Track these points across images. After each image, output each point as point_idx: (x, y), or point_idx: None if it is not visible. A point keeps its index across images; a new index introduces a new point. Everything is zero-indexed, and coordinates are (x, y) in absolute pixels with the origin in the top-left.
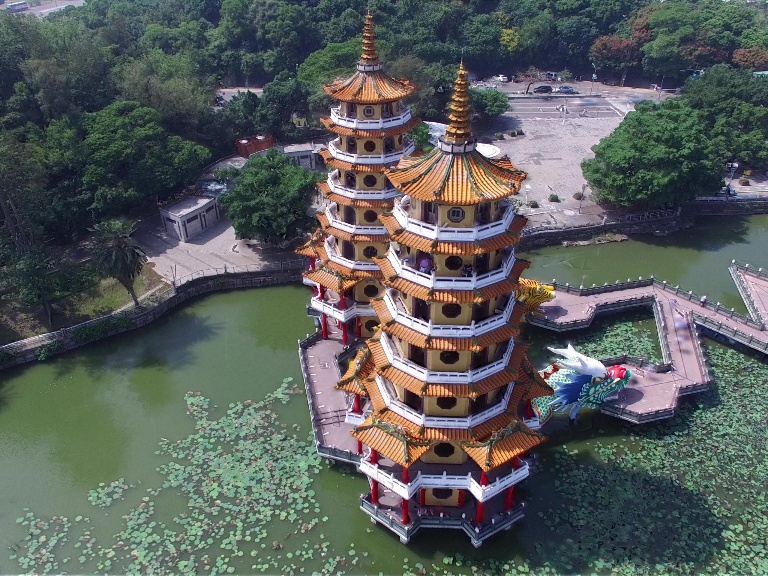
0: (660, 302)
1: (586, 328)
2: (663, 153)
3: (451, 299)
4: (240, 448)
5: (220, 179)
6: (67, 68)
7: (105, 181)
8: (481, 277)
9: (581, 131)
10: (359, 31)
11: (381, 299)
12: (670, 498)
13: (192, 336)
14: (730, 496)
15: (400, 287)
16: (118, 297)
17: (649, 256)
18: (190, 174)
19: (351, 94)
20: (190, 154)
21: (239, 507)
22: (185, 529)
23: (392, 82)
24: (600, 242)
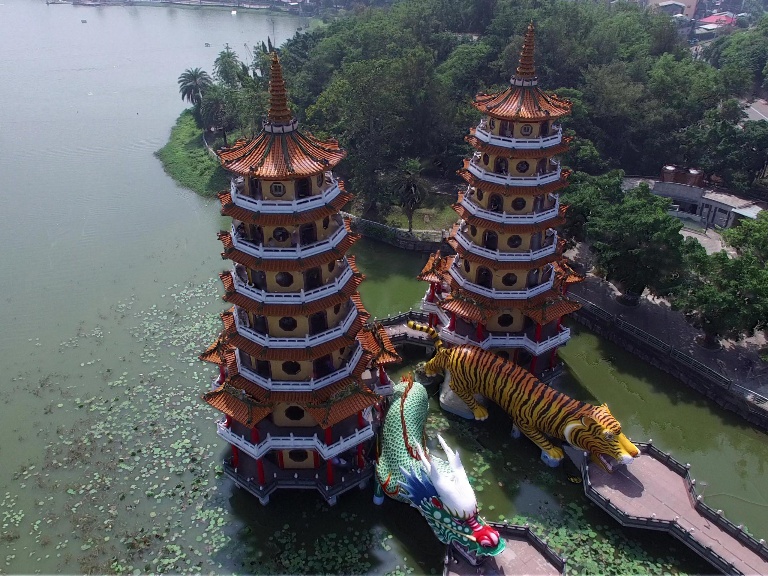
0: None
1: (620, 524)
2: None
3: None
4: None
5: None
6: (557, 50)
7: None
8: (242, 241)
9: None
10: None
11: None
12: None
13: (406, 271)
14: None
15: None
16: (414, 222)
17: None
18: None
19: None
20: None
21: None
22: None
23: (530, 103)
24: None
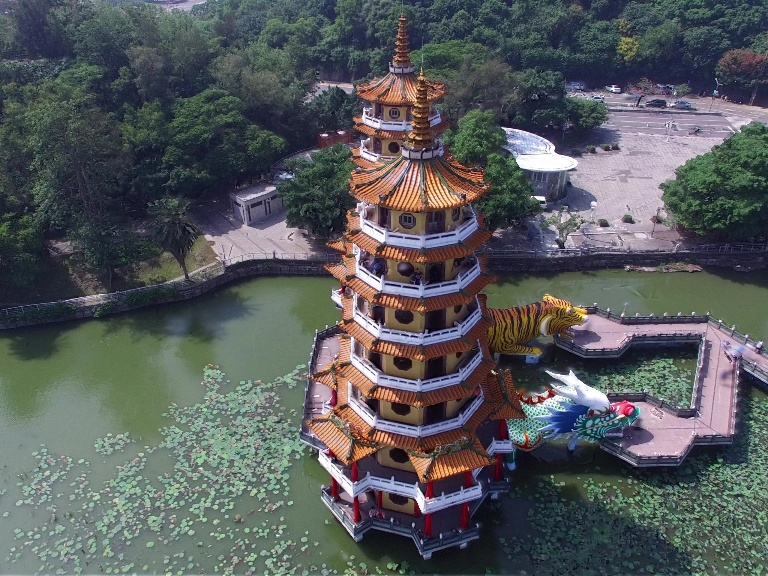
0: (709, 342)
1: (616, 358)
2: (747, 181)
3: (397, 304)
4: (236, 423)
5: (290, 169)
6: (170, 56)
7: (182, 162)
8: (430, 286)
9: (685, 150)
10: (468, 33)
11: (351, 297)
12: (649, 551)
13: (229, 313)
14: (720, 562)
15: (354, 287)
16: (174, 269)
17: (721, 292)
18: (262, 162)
19: (377, 95)
20: (264, 143)
21: (217, 477)
22: (165, 488)
23: None
24: (668, 270)
